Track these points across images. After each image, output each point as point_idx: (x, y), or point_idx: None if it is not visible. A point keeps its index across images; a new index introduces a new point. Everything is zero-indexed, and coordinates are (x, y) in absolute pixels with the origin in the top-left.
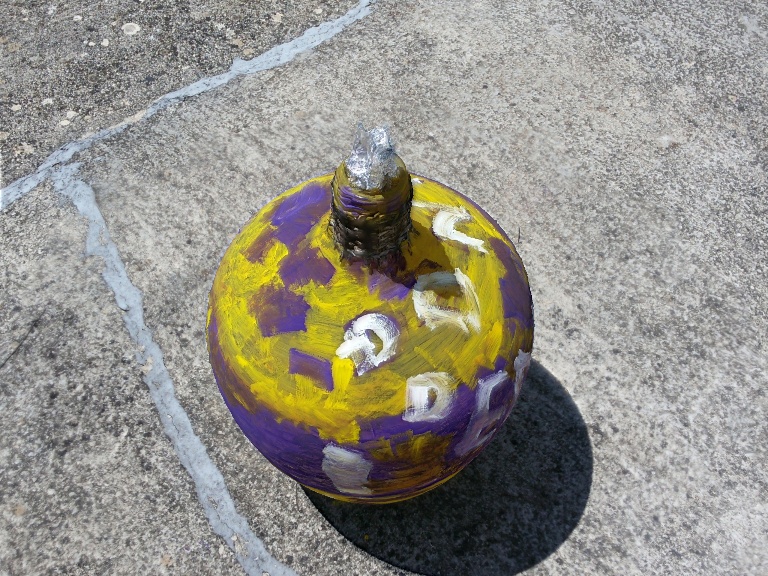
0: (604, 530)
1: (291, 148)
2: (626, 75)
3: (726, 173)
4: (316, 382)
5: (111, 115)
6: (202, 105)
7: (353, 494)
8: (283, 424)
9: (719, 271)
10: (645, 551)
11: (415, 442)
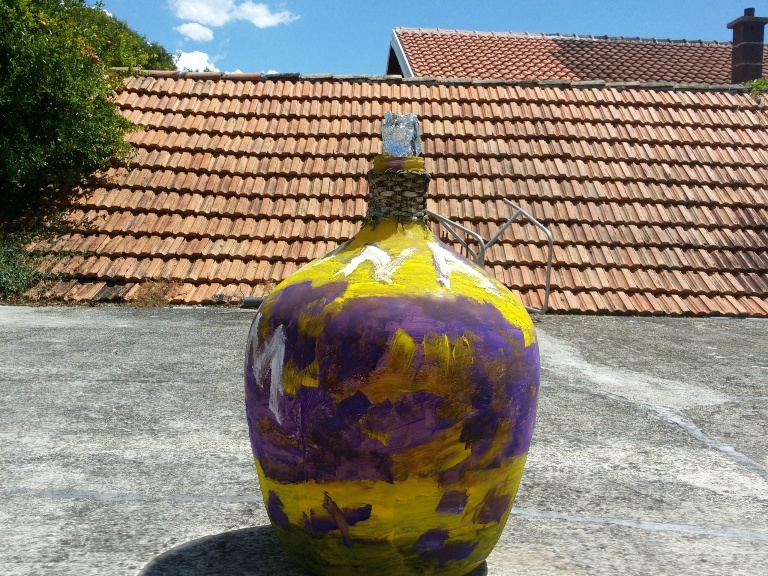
0: None
1: None
2: None
3: None
4: None
5: None
6: None
7: None
8: None
9: None
10: None
11: None
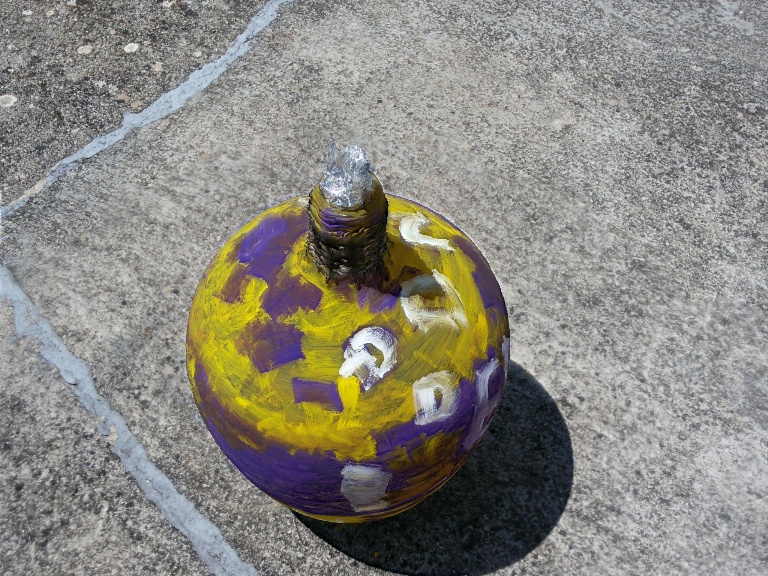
0: (595, 494)
1: (205, 191)
2: (507, 70)
3: (618, 144)
4: (325, 406)
5: (9, 190)
6: (103, 164)
7: (368, 511)
8: (297, 455)
9: (635, 234)
10: (636, 505)
11: (429, 444)
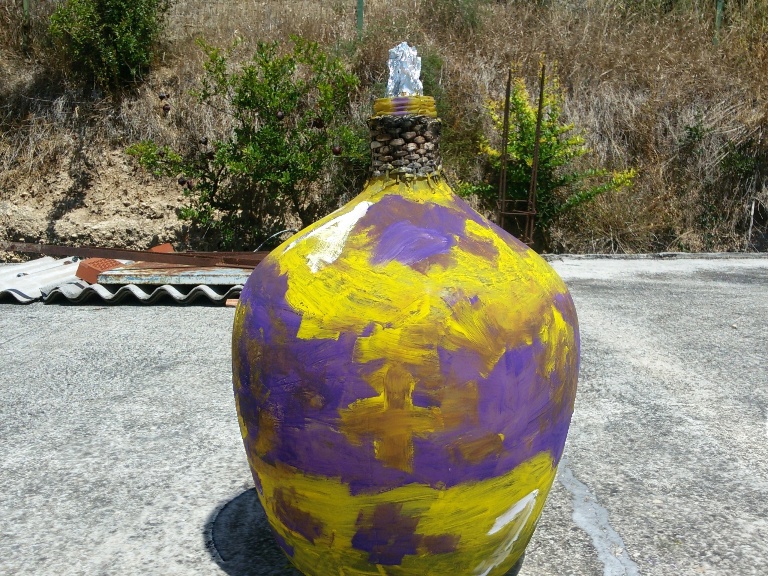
0: None
1: None
2: None
3: None
4: None
5: None
6: None
7: None
8: None
9: None
10: None
11: None
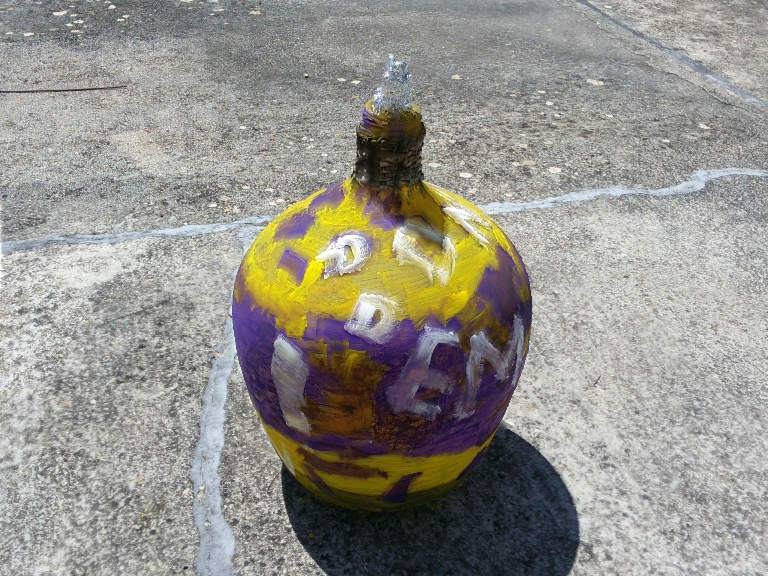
0: None
1: None
2: None
3: None
4: (290, 277)
5: None
6: None
7: (296, 432)
8: (254, 312)
9: None
10: None
11: (349, 358)
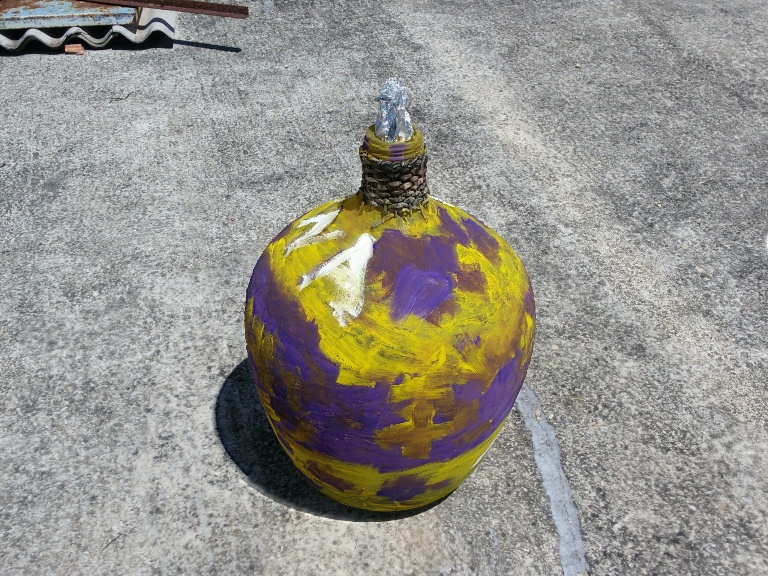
0: None
1: None
2: None
3: None
4: None
5: None
6: None
7: None
8: None
9: None
10: None
11: None
